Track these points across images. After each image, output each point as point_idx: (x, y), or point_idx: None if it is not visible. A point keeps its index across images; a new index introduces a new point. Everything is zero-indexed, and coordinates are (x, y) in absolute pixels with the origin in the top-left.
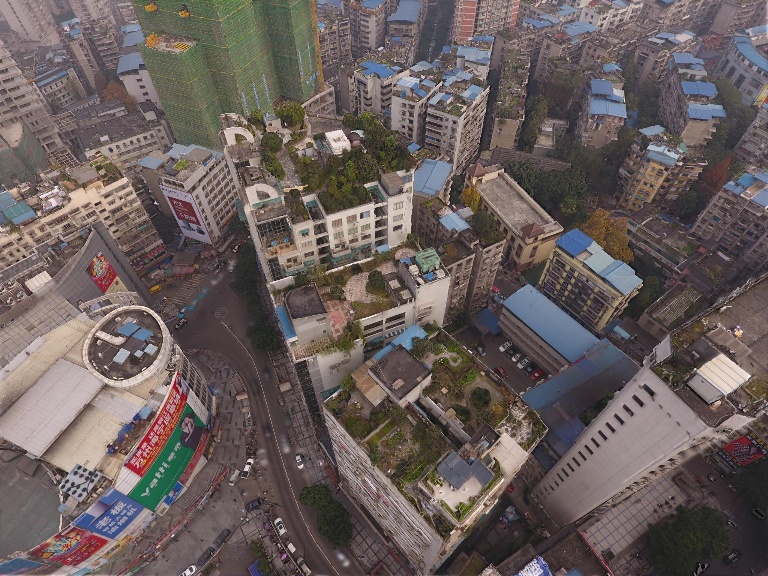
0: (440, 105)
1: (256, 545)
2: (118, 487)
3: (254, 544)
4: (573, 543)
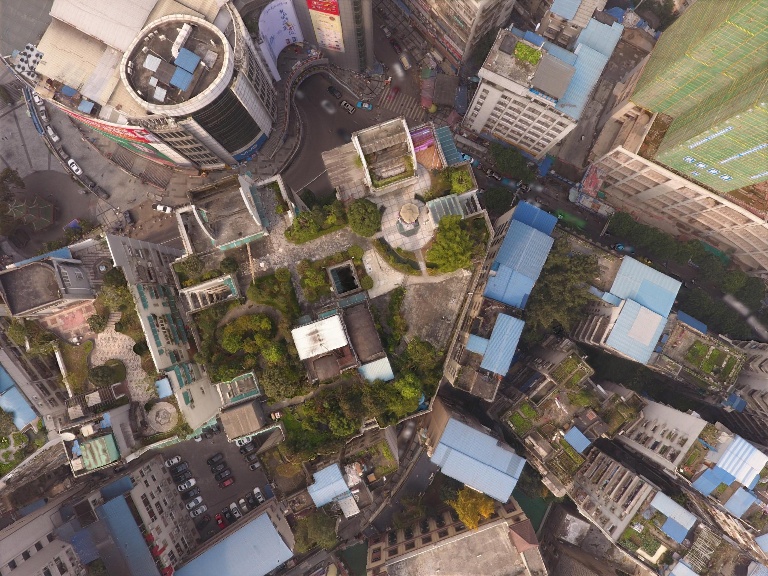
0: (652, 514)
1: (82, 225)
2: None
3: (83, 223)
4: None
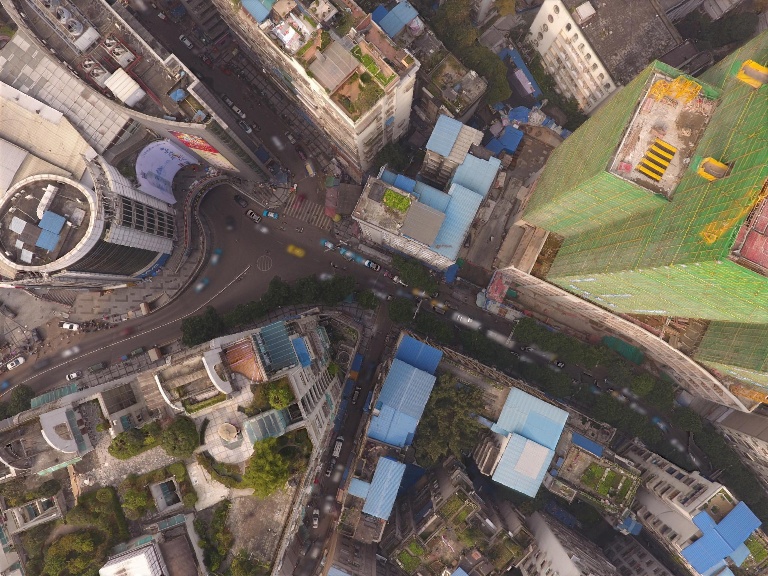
0: None
1: None
2: None
3: None
4: None
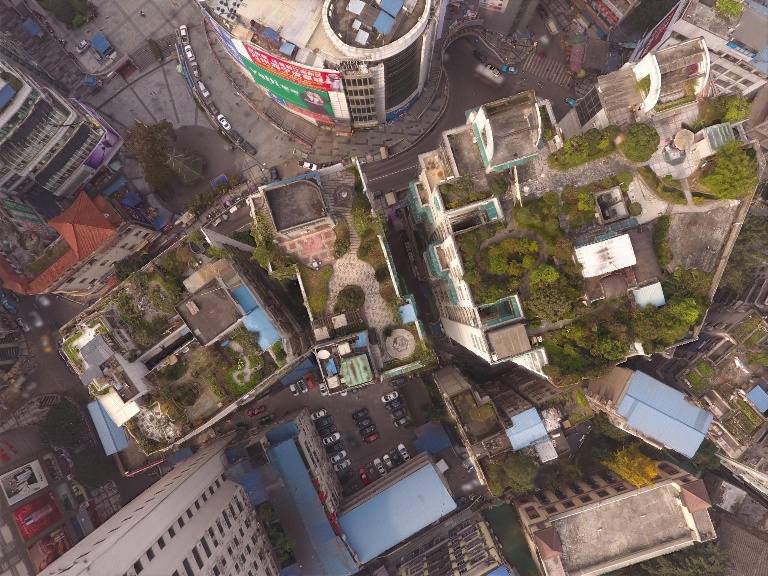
0: None
1: (233, 178)
2: (234, 42)
3: (234, 176)
4: None
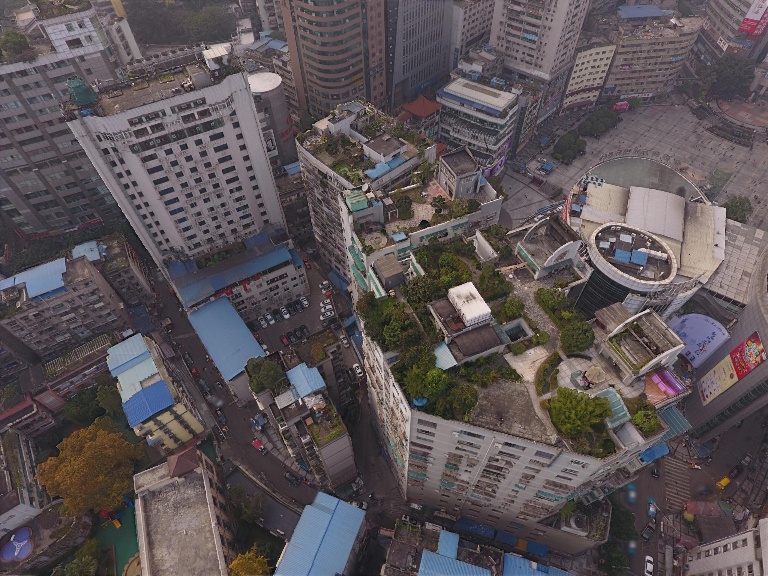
0: None
1: None
2: None
3: None
4: (285, 190)
